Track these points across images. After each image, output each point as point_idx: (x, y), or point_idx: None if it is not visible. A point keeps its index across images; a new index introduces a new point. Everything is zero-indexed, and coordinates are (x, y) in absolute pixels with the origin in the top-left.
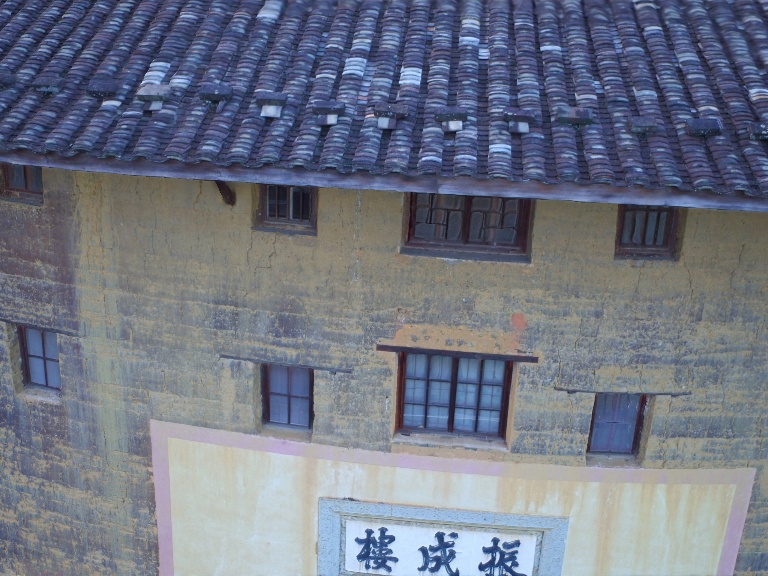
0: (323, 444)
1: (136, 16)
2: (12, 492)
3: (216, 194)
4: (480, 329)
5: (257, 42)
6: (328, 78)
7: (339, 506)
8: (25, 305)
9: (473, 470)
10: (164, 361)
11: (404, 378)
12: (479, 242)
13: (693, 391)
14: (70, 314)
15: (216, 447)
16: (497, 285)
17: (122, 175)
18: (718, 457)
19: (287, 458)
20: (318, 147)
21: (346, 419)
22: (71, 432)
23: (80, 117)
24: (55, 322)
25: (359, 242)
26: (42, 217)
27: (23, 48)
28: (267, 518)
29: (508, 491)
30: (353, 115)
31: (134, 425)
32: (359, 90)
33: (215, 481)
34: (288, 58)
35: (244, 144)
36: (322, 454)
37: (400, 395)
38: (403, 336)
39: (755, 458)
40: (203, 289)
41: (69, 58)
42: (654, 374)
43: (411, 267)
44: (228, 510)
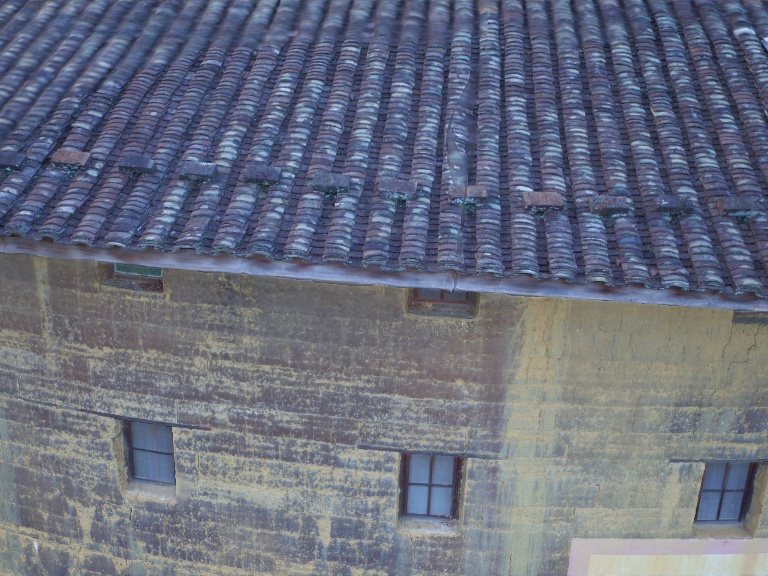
0: (766, 538)
1: (747, 111)
2: None
3: None
4: None
5: None
6: None
7: None
8: (431, 431)
9: None
10: (601, 474)
11: None
12: None
13: None
14: (492, 435)
15: (646, 557)
16: None
17: None
18: None
19: (725, 558)
20: None
21: None
22: (467, 564)
23: None
24: (469, 446)
25: None
26: (473, 331)
27: (650, 160)
28: None
29: None
30: None
31: (551, 547)
32: None
33: None
34: None
35: None
36: (764, 548)
37: None
38: None
39: None
40: (665, 392)
41: (717, 169)
42: None
43: None
44: None
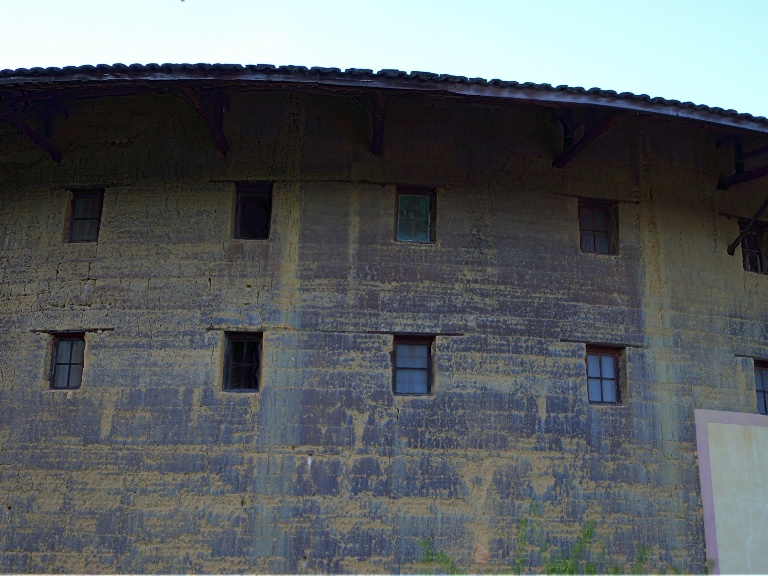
0: None
1: None
2: (579, 503)
3: (724, 248)
4: None
5: None
6: None
7: None
8: (603, 327)
9: None
10: (701, 361)
11: None
12: None
13: None
14: (638, 331)
15: (739, 427)
16: None
17: (671, 235)
18: None
19: None
20: None
21: None
22: (636, 430)
23: None
24: (626, 338)
25: None
26: (619, 263)
27: None
28: None
29: None
30: None
31: (683, 416)
32: None
33: (740, 456)
34: None
35: None
36: None
37: None
38: None
39: None
40: (723, 307)
41: None
42: None
43: None
44: (750, 481)
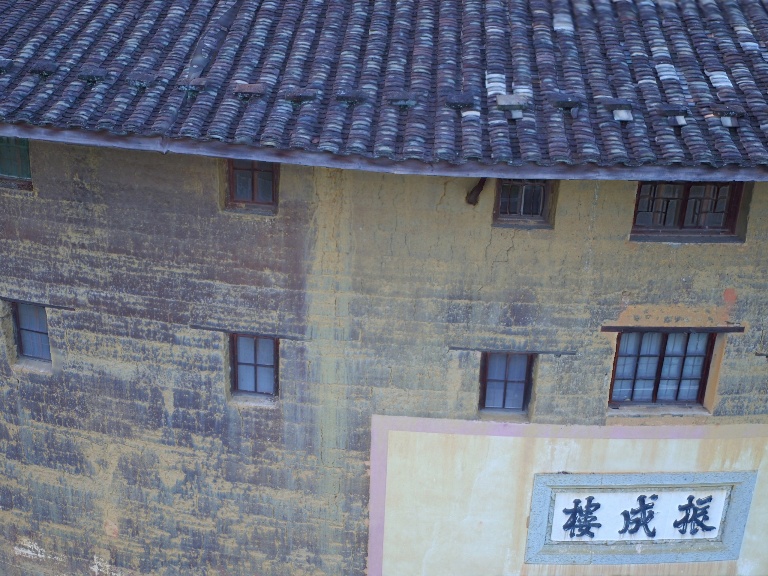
0: (542, 423)
1: (444, 31)
2: (212, 500)
3: (460, 195)
4: (696, 305)
5: (571, 53)
6: (652, 83)
7: (553, 480)
8: (248, 314)
9: (678, 435)
10: (392, 357)
11: (617, 356)
12: (693, 226)
13: None
14: (297, 319)
15: (437, 435)
16: (714, 264)
17: (365, 182)
18: None
19: (507, 440)
20: (682, 145)
21: (566, 398)
22: (286, 434)
23: (451, 128)
24: (279, 328)
25: (593, 232)
26: (276, 227)
27: (351, 65)
28: (482, 499)
29: (708, 451)
30: (693, 116)
31: (355, 422)
32: (683, 93)
33: (433, 468)
34: (604, 66)
35: (618, 146)
36: (541, 433)
37: (612, 372)
38: (626, 317)
39: None
40: (439, 286)
41: (401, 73)
42: None
43: (639, 253)
44: (444, 495)
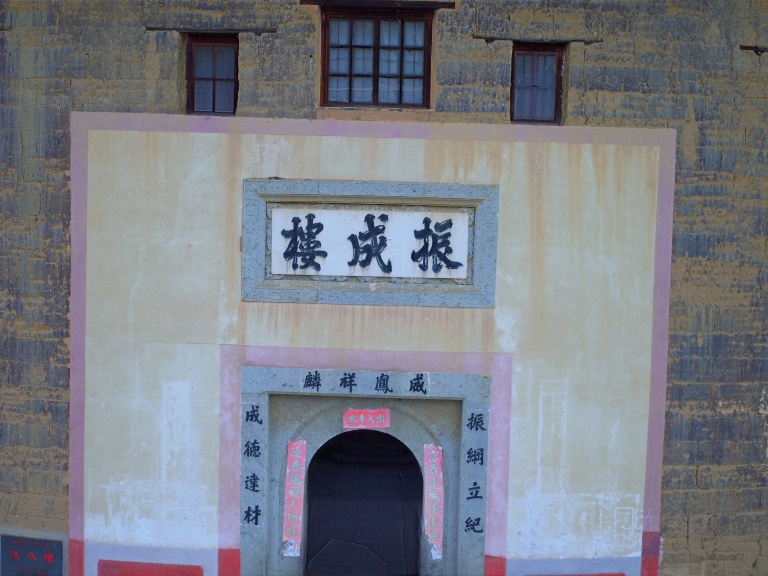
0: (248, 117)
1: None
2: None
3: None
4: None
5: None
6: None
7: (264, 187)
8: None
9: (399, 133)
10: (89, 42)
11: (328, 46)
12: None
13: (604, 39)
14: None
15: (138, 134)
16: None
17: None
18: (638, 115)
19: (211, 137)
20: None
21: (271, 85)
22: None
23: None
24: None
25: None
26: None
27: None
28: (189, 214)
29: (436, 156)
30: None
31: (54, 122)
32: None
33: (135, 176)
34: None
35: None
36: (247, 128)
37: (324, 65)
38: None
39: (673, 118)
40: None
41: None
42: (566, 19)
43: None
44: (148, 209)
